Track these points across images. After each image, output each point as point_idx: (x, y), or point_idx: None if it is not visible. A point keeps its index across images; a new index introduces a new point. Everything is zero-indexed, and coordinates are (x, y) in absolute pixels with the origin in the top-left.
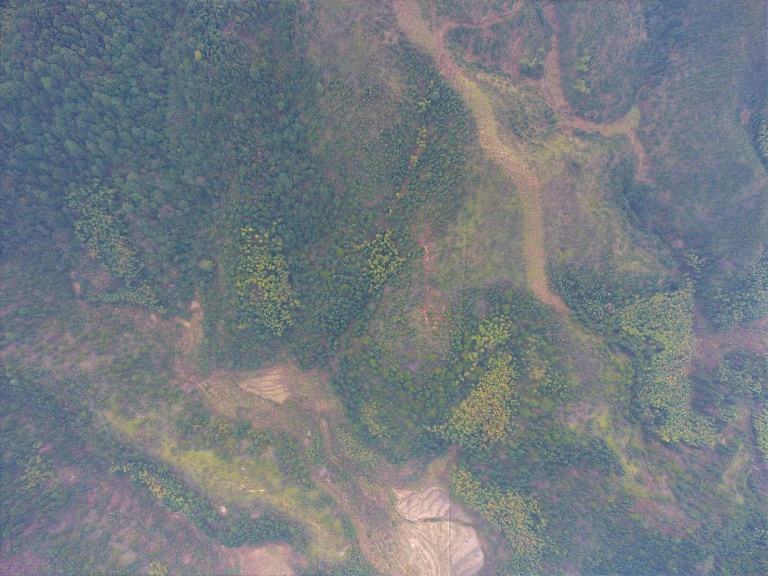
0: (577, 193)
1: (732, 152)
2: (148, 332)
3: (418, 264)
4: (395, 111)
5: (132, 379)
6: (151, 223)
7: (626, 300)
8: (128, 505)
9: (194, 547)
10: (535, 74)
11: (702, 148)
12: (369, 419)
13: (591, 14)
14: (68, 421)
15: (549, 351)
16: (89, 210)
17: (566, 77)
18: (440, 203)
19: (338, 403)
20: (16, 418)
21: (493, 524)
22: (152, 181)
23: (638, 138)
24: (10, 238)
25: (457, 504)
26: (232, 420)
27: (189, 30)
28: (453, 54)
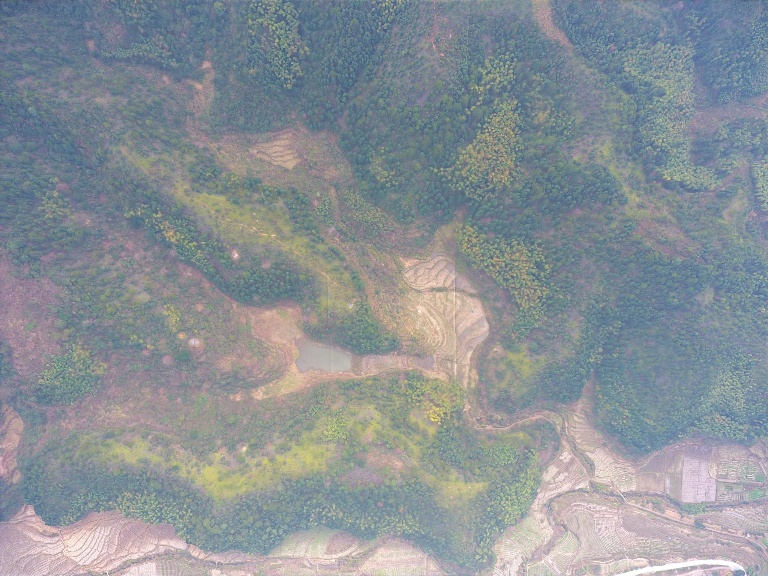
0: None
1: None
2: (161, 88)
3: None
4: None
5: (146, 122)
6: None
7: (628, 42)
8: (142, 254)
9: (206, 301)
10: None
11: None
12: (377, 166)
13: None
14: (83, 168)
15: (553, 87)
16: None
17: None
18: None
19: (346, 166)
20: (33, 156)
21: (498, 281)
22: None
23: None
24: None
25: (463, 273)
26: (243, 177)
27: None
28: None
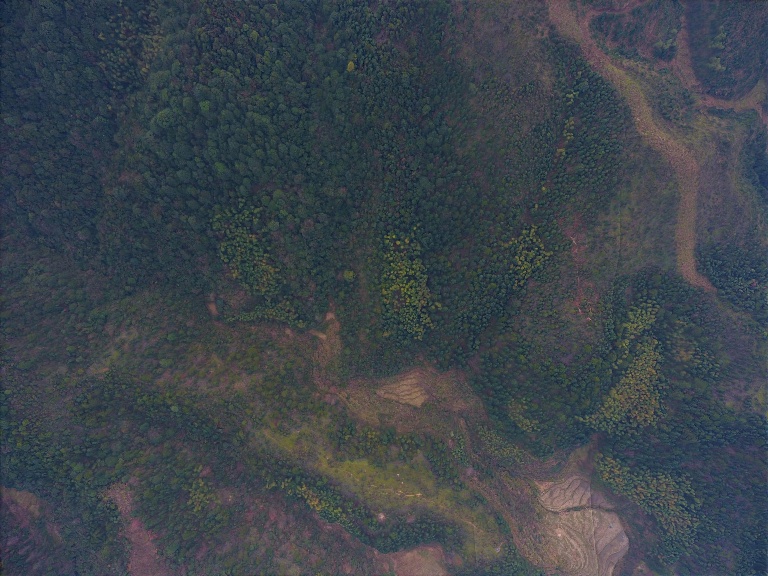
0: (727, 172)
1: None
2: (287, 347)
3: (566, 257)
4: (546, 105)
5: (282, 395)
6: (294, 238)
7: None
8: (285, 520)
9: (350, 556)
10: (667, 56)
11: None
12: (518, 415)
13: None
14: (220, 442)
15: (699, 332)
16: (233, 231)
17: (698, 56)
18: (593, 194)
19: (477, 401)
20: (173, 444)
21: (643, 508)
22: (294, 196)
23: (765, 112)
24: (146, 265)
25: (599, 491)
26: (377, 427)
27: (337, 41)
28: (598, 43)
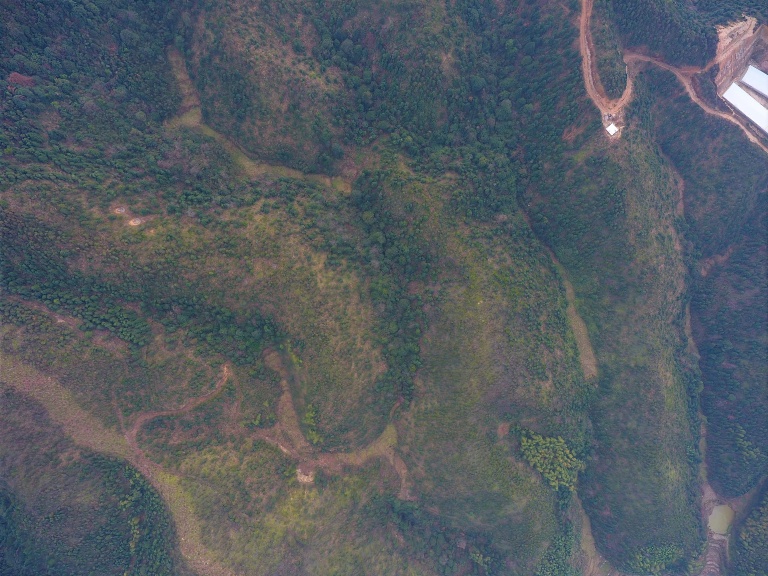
0: (307, 568)
1: (483, 484)
2: None
3: None
4: (93, 518)
5: None
6: None
7: None
8: None
9: None
10: (266, 424)
11: (452, 481)
12: None
13: (308, 373)
14: None
15: None
16: None
17: (300, 422)
18: None
19: None
20: None
21: None
22: None
23: (398, 455)
24: None
25: None
26: None
27: None
28: (153, 447)
